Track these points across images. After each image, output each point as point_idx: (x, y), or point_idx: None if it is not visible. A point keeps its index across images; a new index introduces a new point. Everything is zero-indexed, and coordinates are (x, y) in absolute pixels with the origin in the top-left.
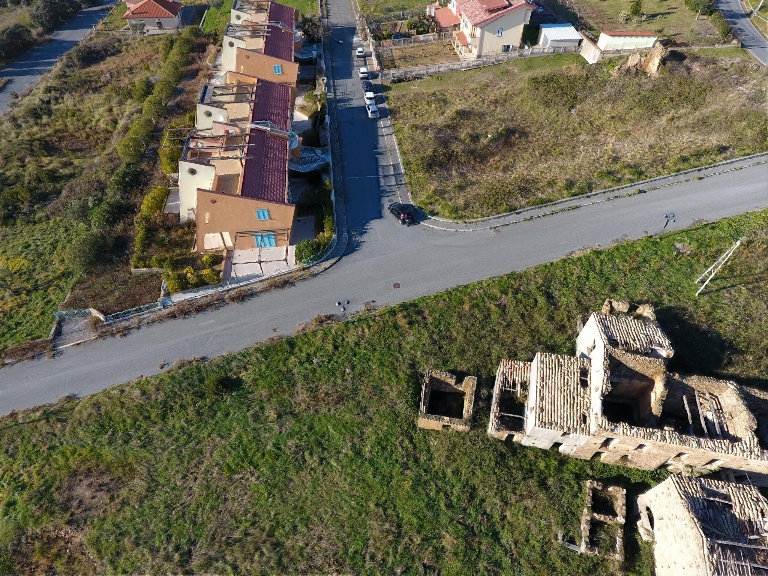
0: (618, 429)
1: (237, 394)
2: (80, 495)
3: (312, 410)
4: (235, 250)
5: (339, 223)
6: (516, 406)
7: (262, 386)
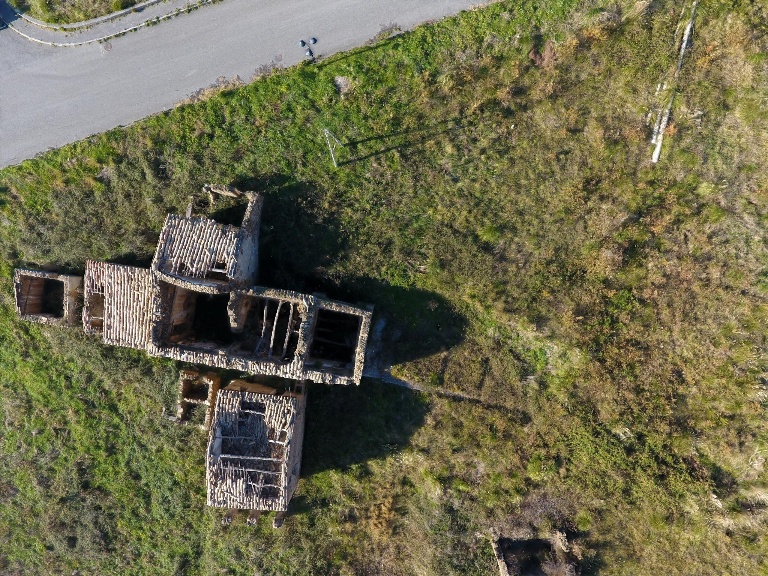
0: (169, 354)
1: None
2: None
3: None
4: None
5: None
6: None
7: None
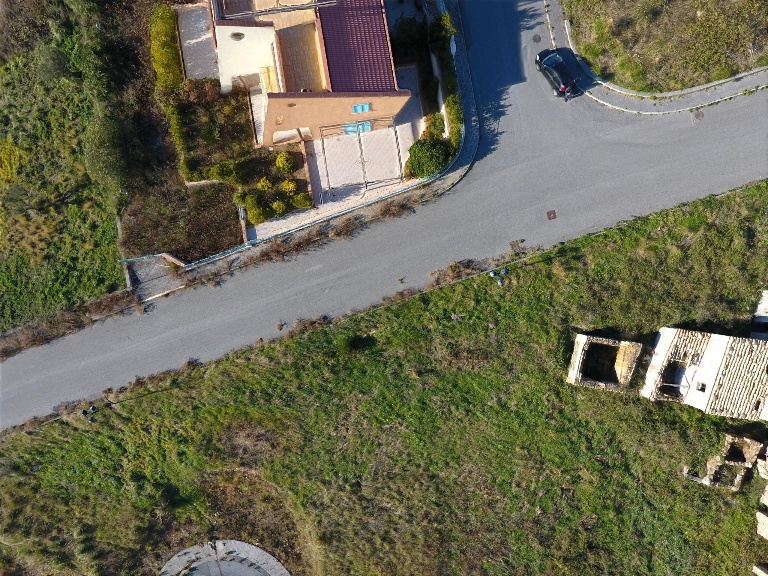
0: None
1: (371, 353)
2: (242, 444)
3: (455, 368)
4: (315, 140)
5: (464, 96)
6: (674, 365)
7: (397, 344)
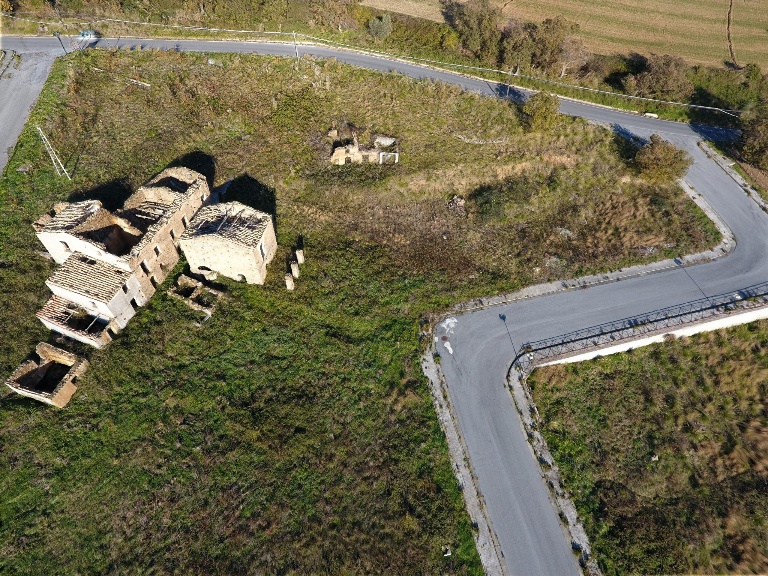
0: (134, 252)
1: None
2: None
3: None
4: None
5: None
6: (88, 322)
7: None
